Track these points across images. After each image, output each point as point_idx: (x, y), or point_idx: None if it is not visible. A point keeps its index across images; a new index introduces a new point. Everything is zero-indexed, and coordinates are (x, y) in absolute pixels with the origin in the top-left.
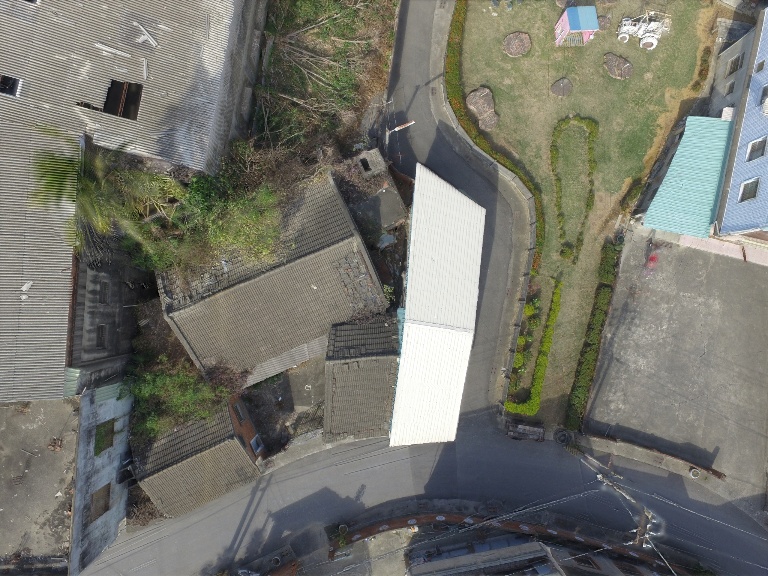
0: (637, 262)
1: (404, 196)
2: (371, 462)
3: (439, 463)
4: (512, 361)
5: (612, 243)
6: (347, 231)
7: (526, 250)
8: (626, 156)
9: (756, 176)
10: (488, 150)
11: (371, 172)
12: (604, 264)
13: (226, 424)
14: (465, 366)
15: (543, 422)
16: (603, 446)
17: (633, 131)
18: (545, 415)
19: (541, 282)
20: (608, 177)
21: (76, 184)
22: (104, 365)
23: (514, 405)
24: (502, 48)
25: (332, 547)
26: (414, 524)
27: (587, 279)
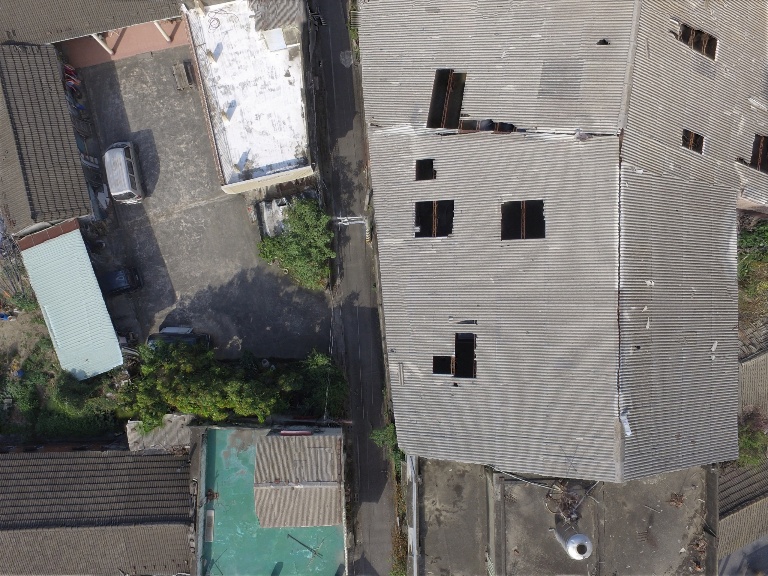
0: None
1: None
2: None
3: None
4: None
5: None
6: None
7: None
8: None
9: None
10: None
11: None
12: None
13: None
14: None
15: None
16: None
17: None
18: None
19: None
20: None
21: None
22: None
23: None
24: None
25: None
26: None
27: None
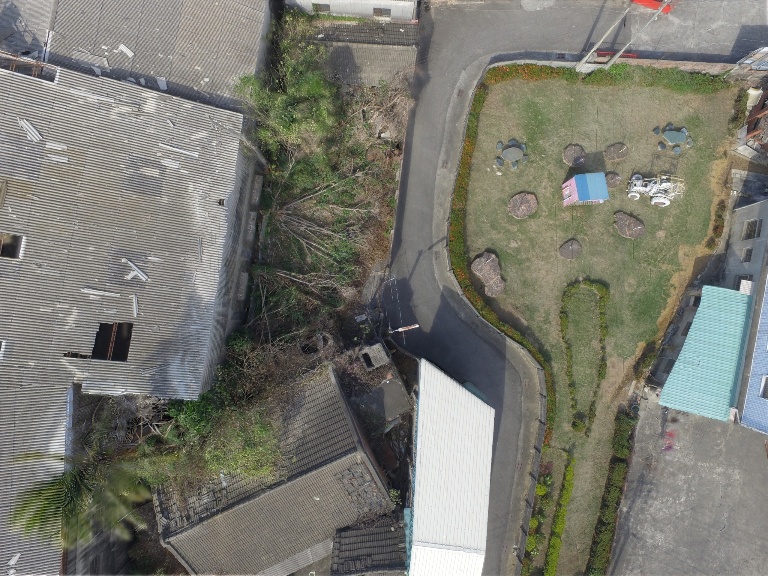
0: (652, 431)
1: (408, 369)
2: None
3: None
4: (524, 545)
5: (626, 412)
6: (350, 442)
7: (536, 420)
8: (639, 318)
9: None
10: (495, 322)
11: (374, 368)
12: (618, 437)
13: None
14: None
15: None
16: None
17: (646, 292)
18: None
19: (553, 455)
20: (620, 342)
21: (64, 440)
22: None
23: None
24: (507, 209)
25: None
26: None
27: (600, 450)
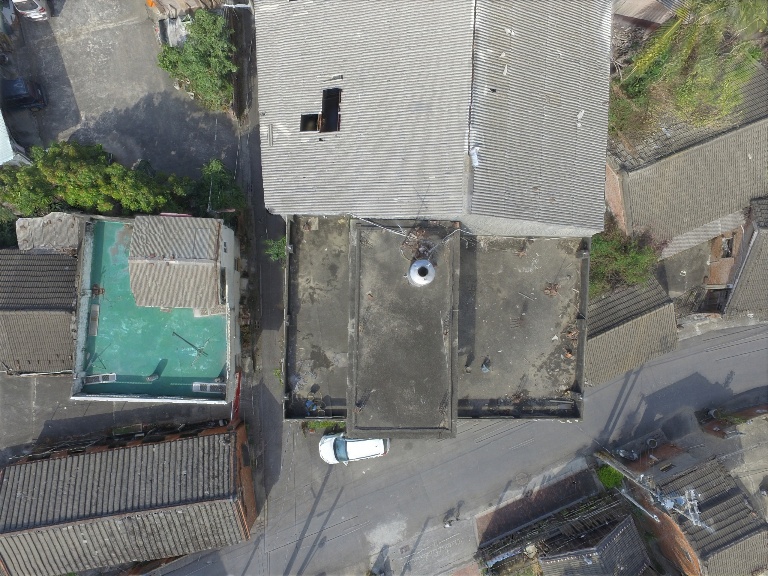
0: None
1: None
2: (740, 349)
3: None
4: None
5: None
6: None
7: None
8: None
9: None
10: None
11: None
12: None
13: (658, 291)
14: None
15: None
16: None
17: None
18: None
19: None
20: None
21: None
22: None
23: None
24: None
25: (717, 427)
26: None
27: None
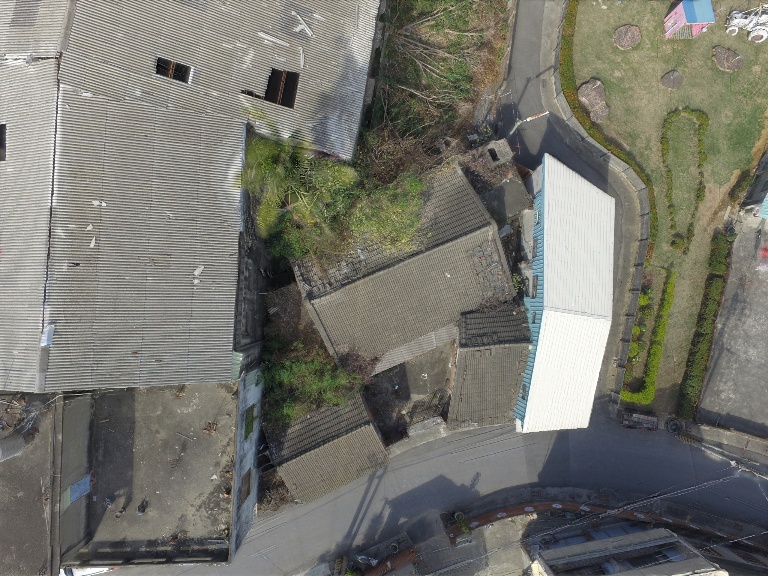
0: (746, 253)
1: None
2: (486, 450)
3: (552, 451)
4: (627, 350)
5: (722, 234)
6: (482, 220)
7: (636, 241)
8: (734, 148)
9: None
10: (602, 141)
11: (499, 162)
12: (716, 255)
13: (360, 410)
14: (601, 353)
15: (655, 411)
16: (713, 435)
17: (741, 123)
18: (657, 404)
19: (652, 273)
20: (717, 169)
21: (241, 171)
22: (250, 351)
23: (630, 394)
24: (612, 41)
25: (452, 534)
26: (533, 511)
27: (697, 270)
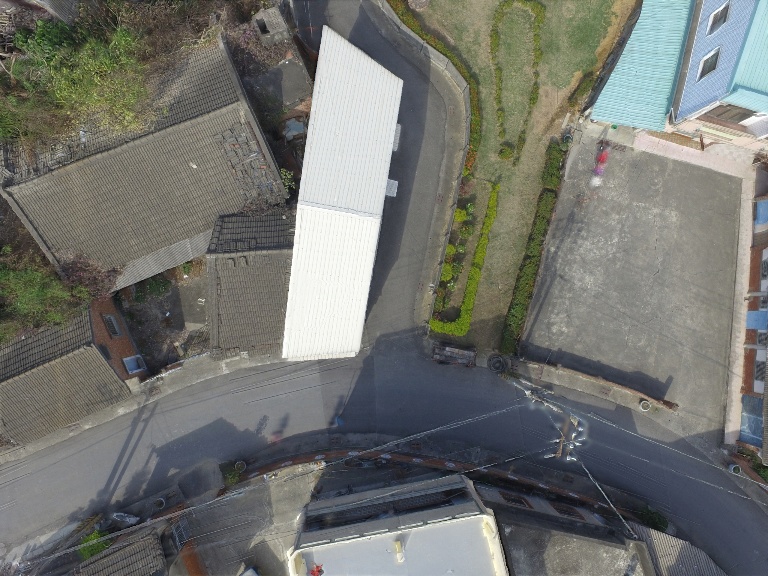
0: (586, 167)
1: None
2: (275, 389)
3: (355, 392)
4: (440, 273)
5: (558, 144)
6: (233, 97)
7: (460, 150)
8: (576, 47)
9: (716, 46)
10: (417, 29)
11: (269, 35)
12: (548, 166)
13: (84, 330)
14: (371, 260)
15: (476, 346)
16: (543, 375)
17: (585, 18)
18: (478, 338)
19: (477, 187)
20: (555, 70)
21: None
22: None
23: (441, 323)
24: None
25: (224, 485)
26: (321, 459)
27: (529, 185)
